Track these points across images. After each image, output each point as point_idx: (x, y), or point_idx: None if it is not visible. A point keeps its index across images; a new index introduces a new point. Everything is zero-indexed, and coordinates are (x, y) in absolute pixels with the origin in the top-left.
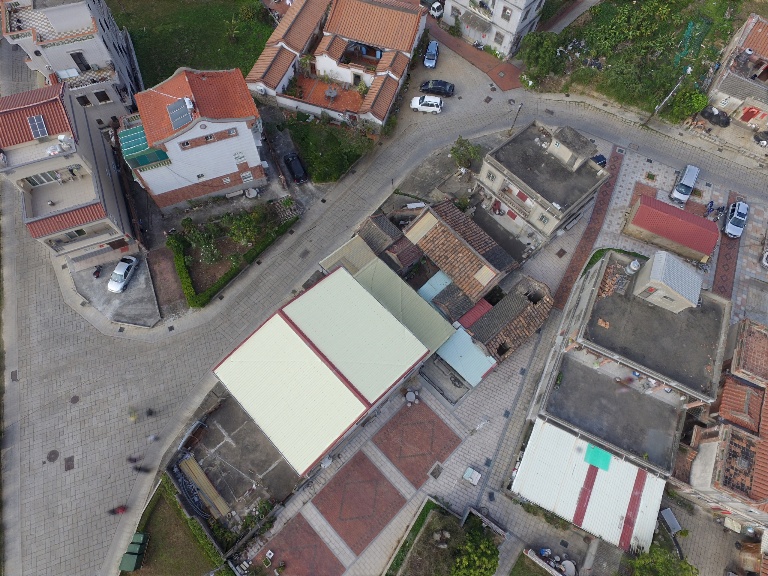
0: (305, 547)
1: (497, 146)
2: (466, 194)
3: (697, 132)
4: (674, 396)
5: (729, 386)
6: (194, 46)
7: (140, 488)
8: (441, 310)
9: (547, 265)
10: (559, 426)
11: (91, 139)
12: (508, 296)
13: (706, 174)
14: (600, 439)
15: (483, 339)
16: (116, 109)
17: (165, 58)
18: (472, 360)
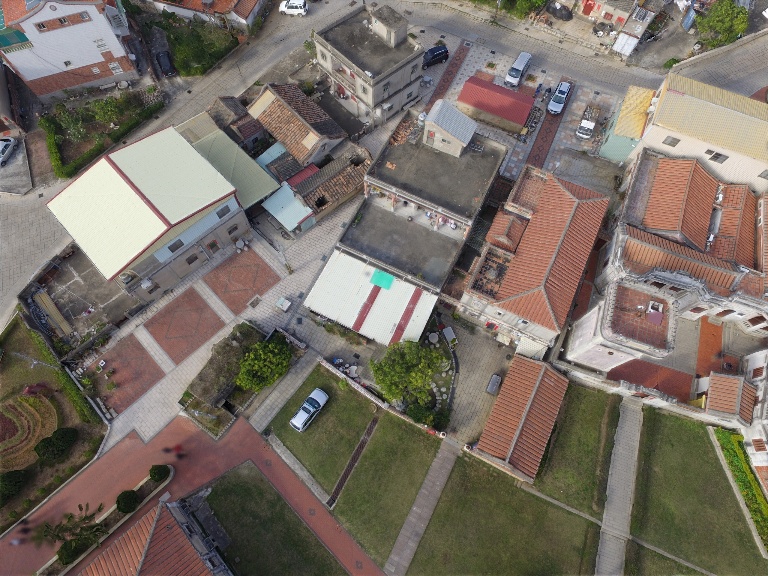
0: (133, 358)
1: None
2: (314, 81)
3: (541, 26)
4: (459, 232)
5: (498, 217)
6: None
7: (1, 317)
8: (272, 172)
9: (381, 140)
10: (352, 255)
11: None
12: (334, 161)
13: (543, 62)
14: (382, 262)
15: None
16: None
17: None
18: (291, 210)
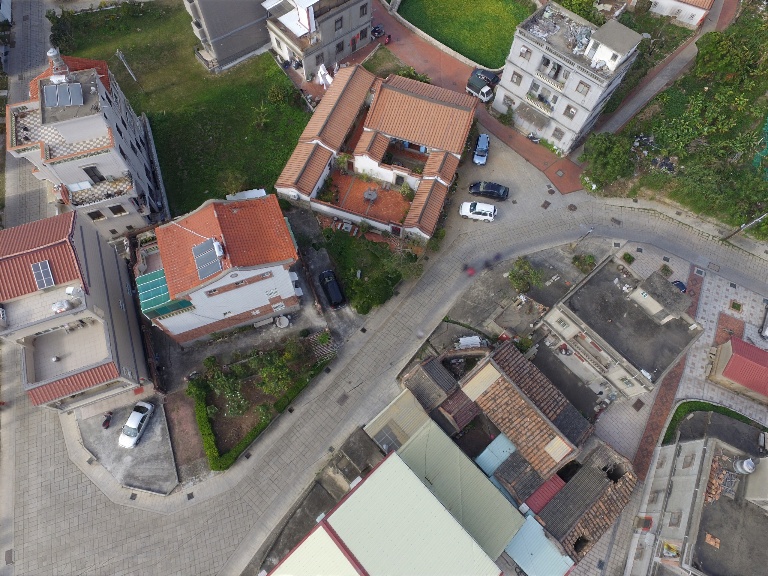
0: None
1: (572, 292)
2: (527, 329)
3: None
4: None
5: None
6: (218, 133)
7: None
8: (506, 488)
9: (623, 420)
10: None
11: (104, 272)
12: (583, 470)
13: None
14: None
15: (558, 532)
16: (132, 219)
17: (186, 147)
18: (545, 560)
